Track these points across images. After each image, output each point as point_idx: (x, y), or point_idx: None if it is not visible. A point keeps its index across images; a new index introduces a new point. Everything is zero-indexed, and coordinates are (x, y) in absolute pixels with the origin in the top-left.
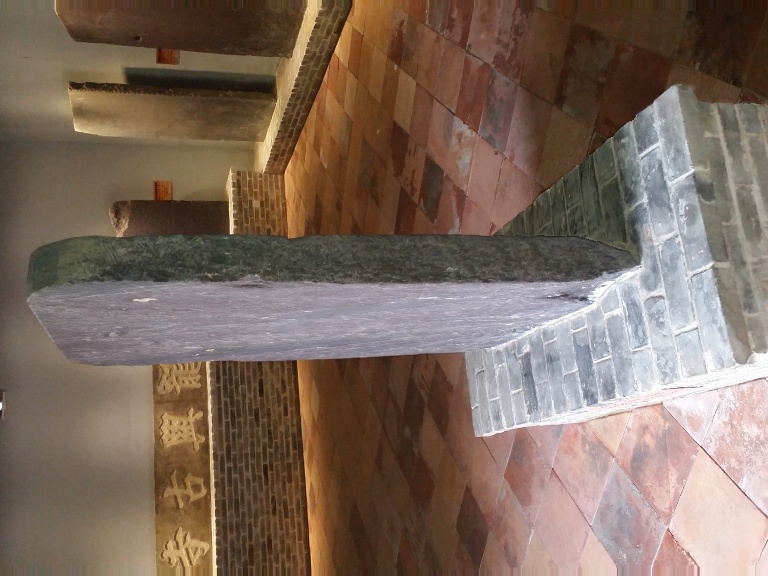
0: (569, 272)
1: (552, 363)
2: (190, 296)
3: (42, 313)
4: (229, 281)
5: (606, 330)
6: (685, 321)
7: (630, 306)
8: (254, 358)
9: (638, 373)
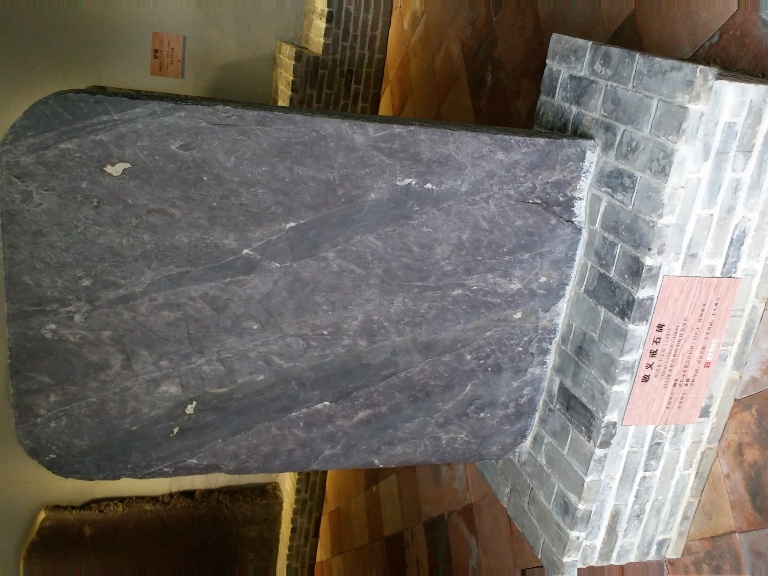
0: (530, 135)
1: (582, 349)
2: (164, 157)
3: (7, 210)
4: (202, 106)
5: (604, 234)
6: (648, 111)
7: (608, 181)
8: (246, 459)
9: (646, 211)
